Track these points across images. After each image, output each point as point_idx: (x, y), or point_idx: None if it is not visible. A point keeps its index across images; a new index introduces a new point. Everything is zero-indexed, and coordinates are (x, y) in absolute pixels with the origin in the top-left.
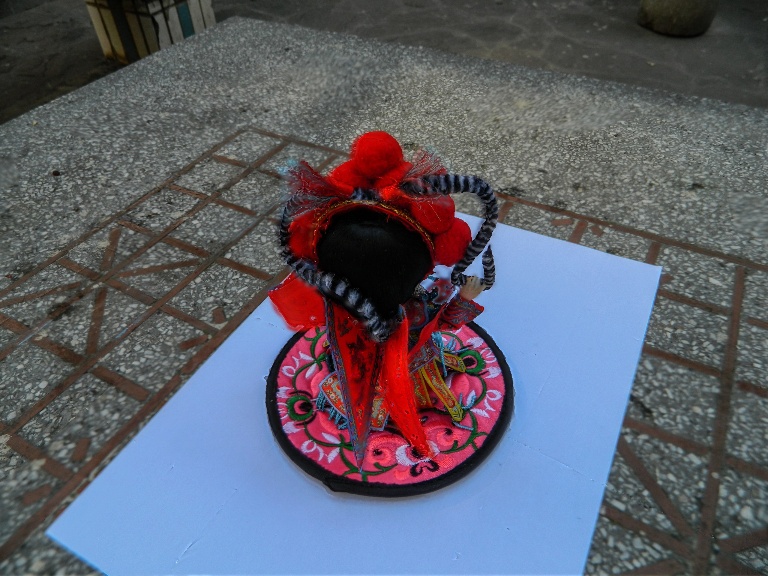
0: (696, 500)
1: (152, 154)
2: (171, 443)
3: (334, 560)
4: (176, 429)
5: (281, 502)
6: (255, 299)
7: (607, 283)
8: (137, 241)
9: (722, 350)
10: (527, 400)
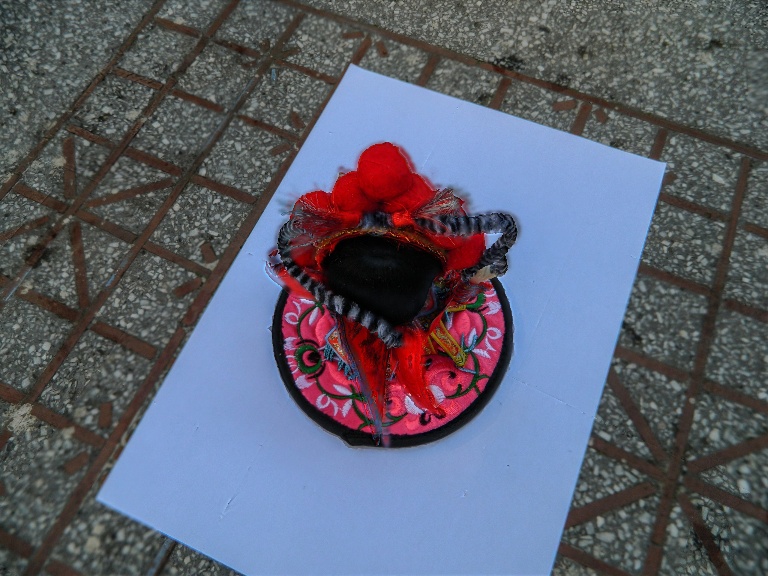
0: (673, 426)
1: (81, 20)
2: (191, 403)
3: (359, 505)
4: (192, 388)
5: (304, 455)
6: (242, 229)
7: (608, 188)
8: (96, 156)
9: (715, 264)
10: (525, 334)
